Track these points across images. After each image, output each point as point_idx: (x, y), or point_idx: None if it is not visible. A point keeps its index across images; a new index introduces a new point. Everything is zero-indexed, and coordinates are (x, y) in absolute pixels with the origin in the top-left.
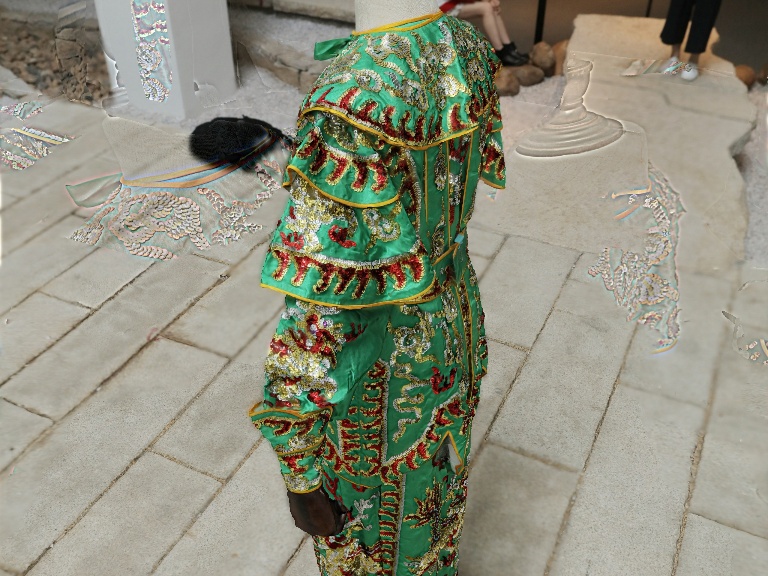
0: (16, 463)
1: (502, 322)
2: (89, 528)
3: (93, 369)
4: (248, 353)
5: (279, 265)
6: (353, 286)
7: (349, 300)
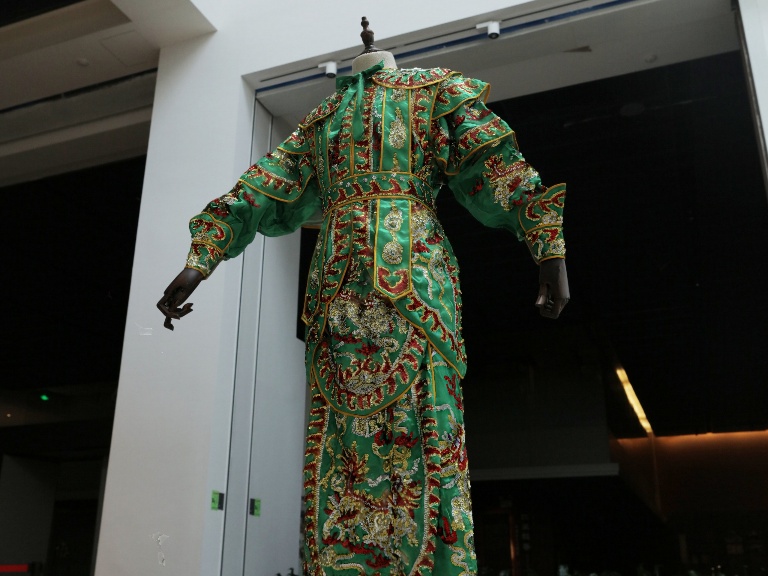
0: None
1: None
2: None
3: None
4: None
5: None
6: None
7: None
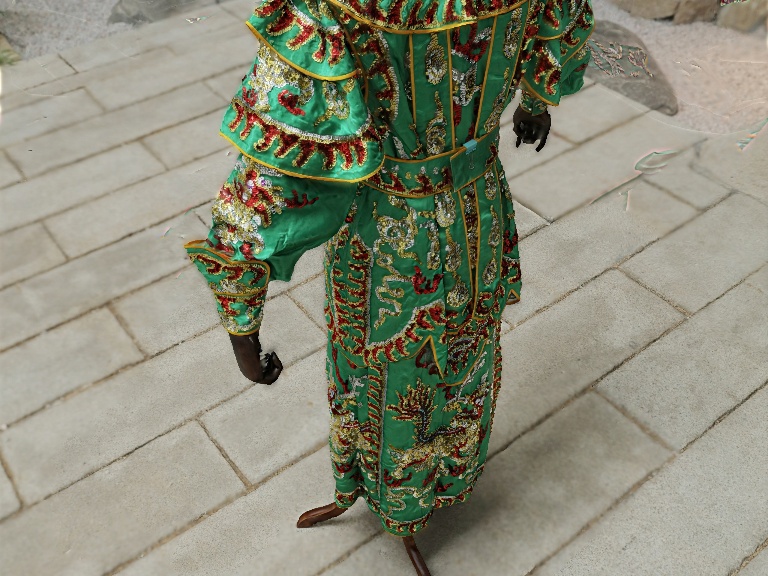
0: (184, 270)
1: (676, 278)
2: (212, 340)
3: None
4: None
5: (236, 117)
6: (295, 153)
7: (290, 166)
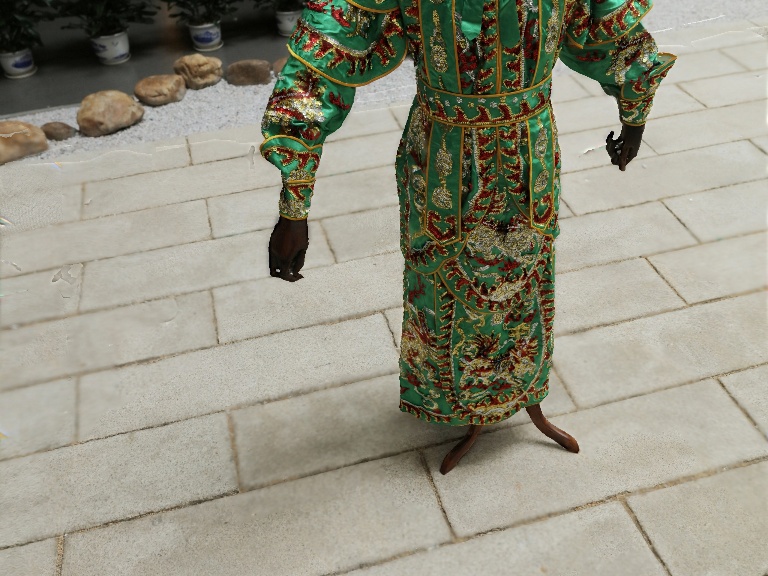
0: None
1: None
2: None
3: None
4: None
5: None
6: None
7: None
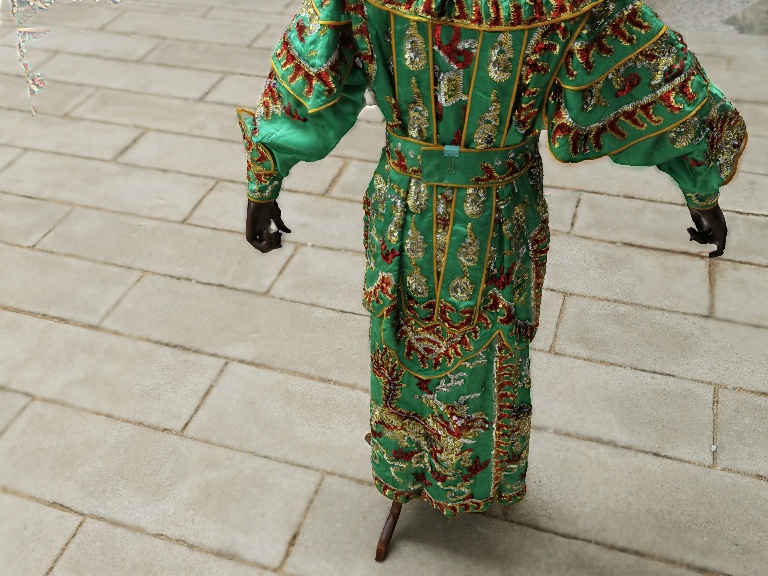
0: None
1: None
2: None
3: (639, 232)
4: (726, 326)
5: None
6: (290, 71)
7: (287, 80)
